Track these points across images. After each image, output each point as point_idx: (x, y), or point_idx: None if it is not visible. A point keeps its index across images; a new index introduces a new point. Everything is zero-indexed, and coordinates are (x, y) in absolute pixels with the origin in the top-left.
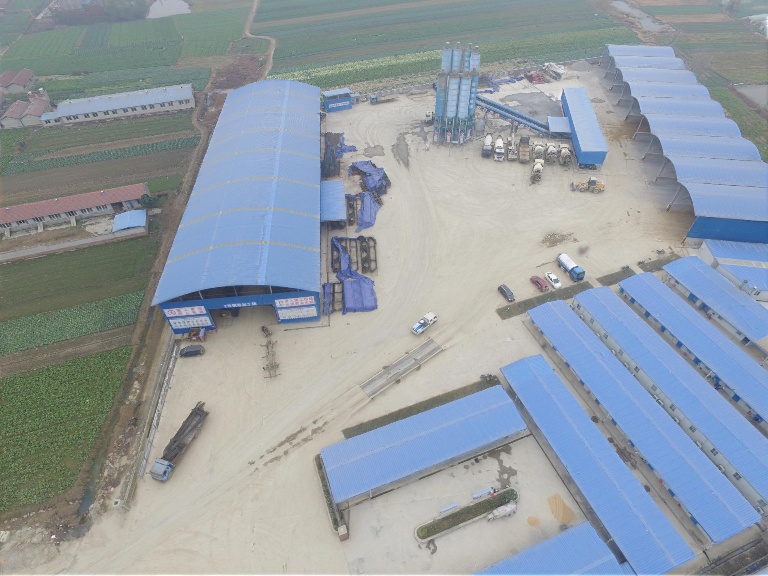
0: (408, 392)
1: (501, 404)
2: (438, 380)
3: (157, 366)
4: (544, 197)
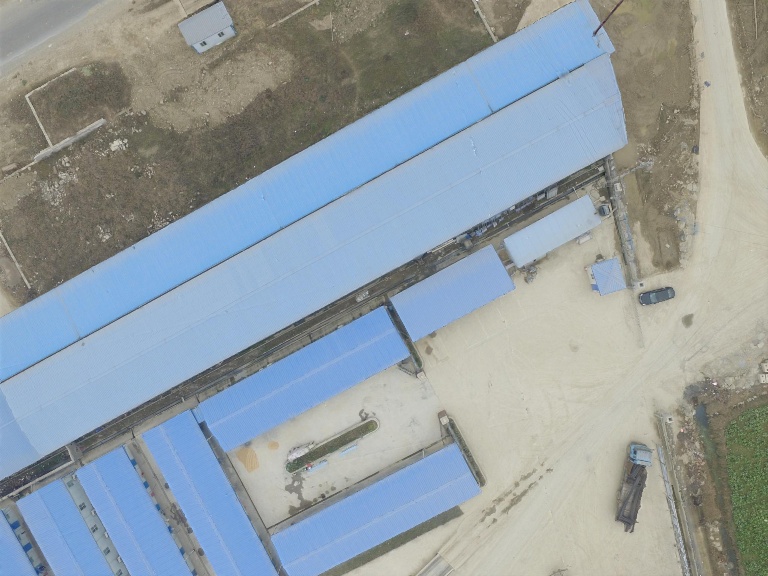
0: (398, 566)
1: (296, 562)
2: None
3: (706, 573)
4: None
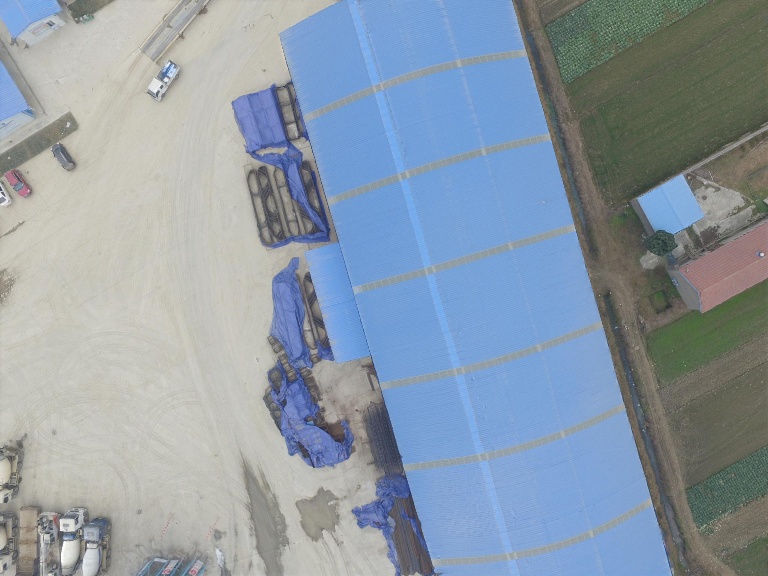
0: None
1: None
2: (141, 5)
3: None
4: (4, 402)
